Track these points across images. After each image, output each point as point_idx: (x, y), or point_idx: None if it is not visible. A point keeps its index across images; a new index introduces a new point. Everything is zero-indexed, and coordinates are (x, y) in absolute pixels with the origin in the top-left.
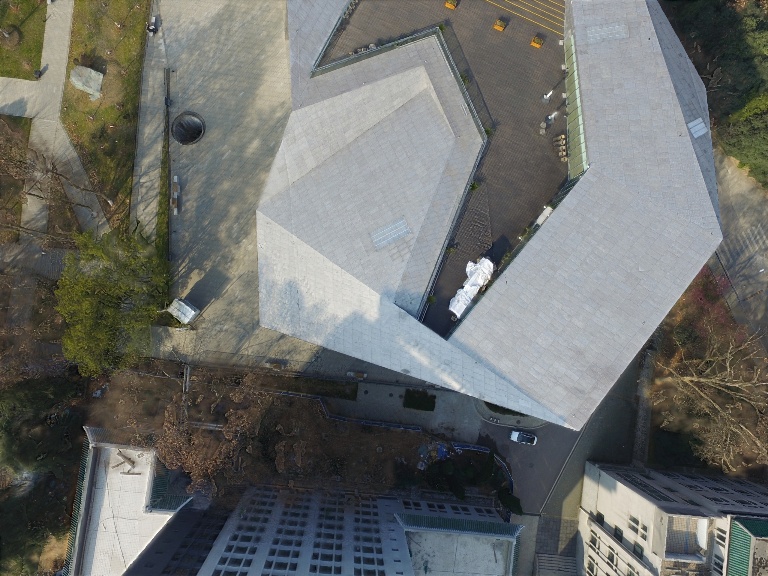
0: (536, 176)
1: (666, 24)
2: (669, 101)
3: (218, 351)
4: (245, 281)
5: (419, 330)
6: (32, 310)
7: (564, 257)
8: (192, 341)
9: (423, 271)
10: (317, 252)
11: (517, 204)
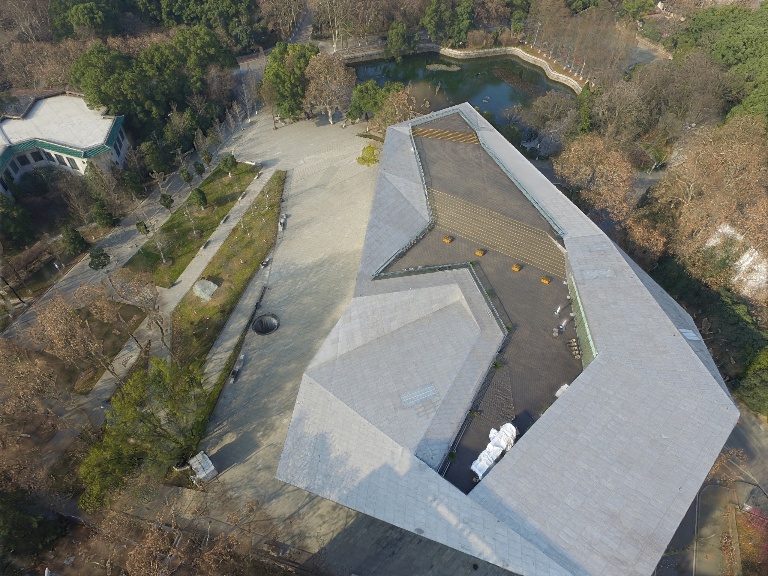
0: (553, 367)
1: (645, 274)
2: (658, 313)
3: (219, 520)
4: (271, 451)
5: (438, 483)
6: (62, 456)
7: (585, 422)
8: (198, 504)
9: (447, 430)
10: (349, 407)
11: (537, 386)
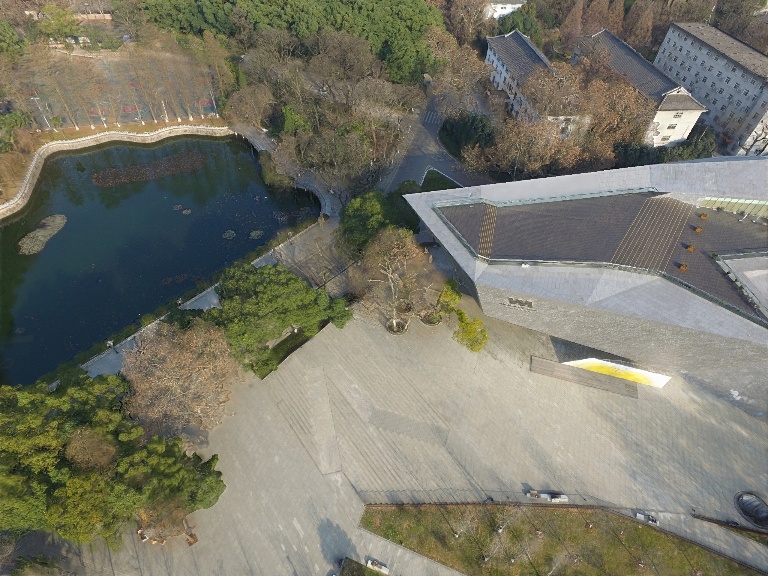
0: None
1: None
2: (763, 163)
3: None
4: None
5: None
6: None
7: None
8: None
9: None
10: None
11: None
